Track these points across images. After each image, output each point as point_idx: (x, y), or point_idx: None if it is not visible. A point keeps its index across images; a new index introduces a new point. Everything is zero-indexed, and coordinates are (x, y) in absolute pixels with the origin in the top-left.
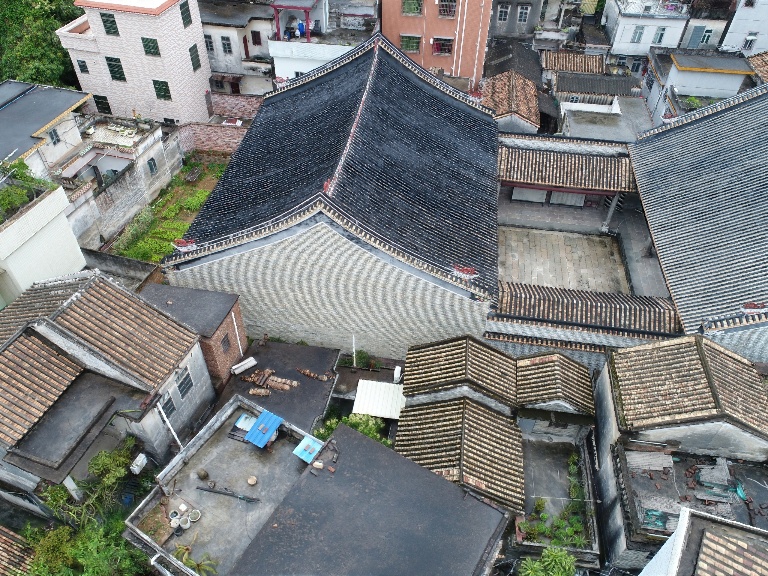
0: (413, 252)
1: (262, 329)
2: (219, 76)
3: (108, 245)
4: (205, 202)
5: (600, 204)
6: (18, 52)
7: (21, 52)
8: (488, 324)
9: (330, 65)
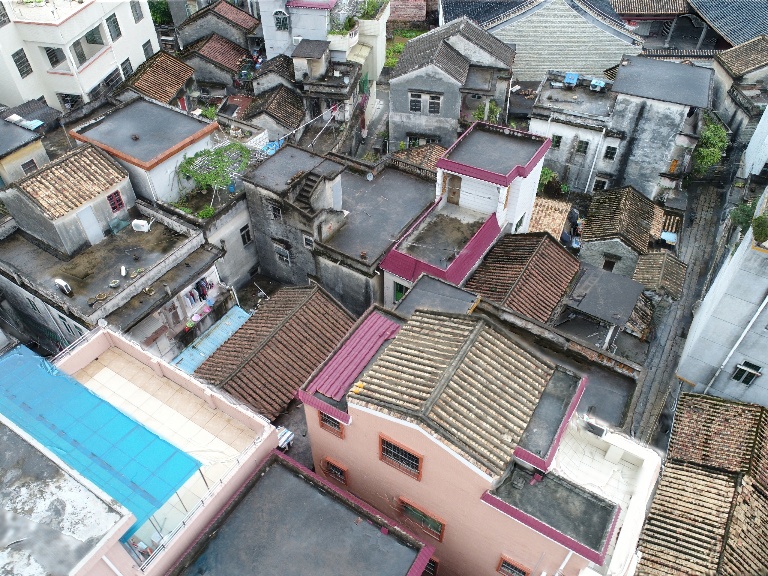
0: (605, 14)
1: None
2: None
3: None
4: None
5: (659, 34)
6: None
7: None
8: None
9: None
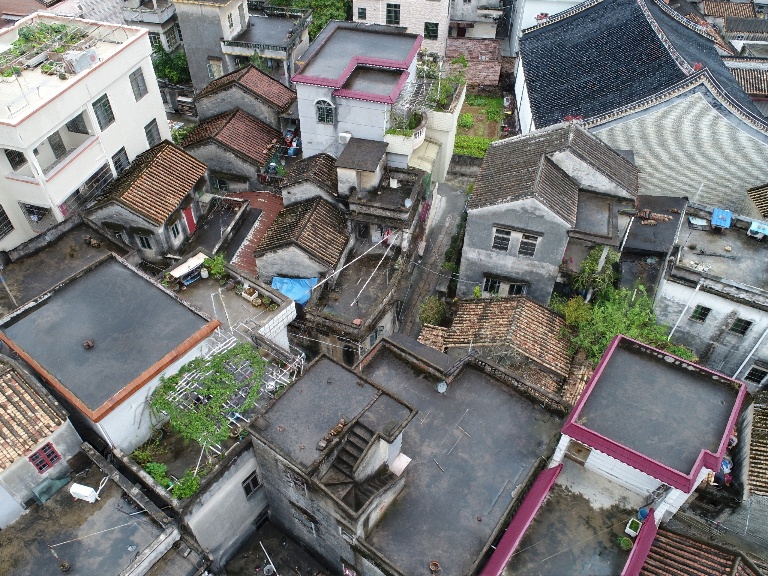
0: (756, 116)
1: None
2: (454, 23)
3: None
4: (531, 105)
5: None
6: (313, 1)
7: (315, 1)
8: None
9: (588, 3)
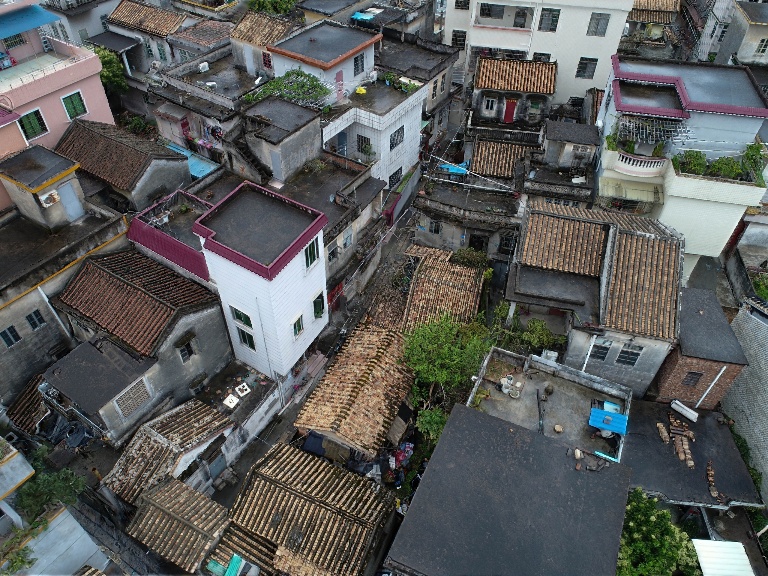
0: None
1: (748, 426)
2: None
3: (759, 270)
4: None
5: None
6: None
7: None
8: None
9: None
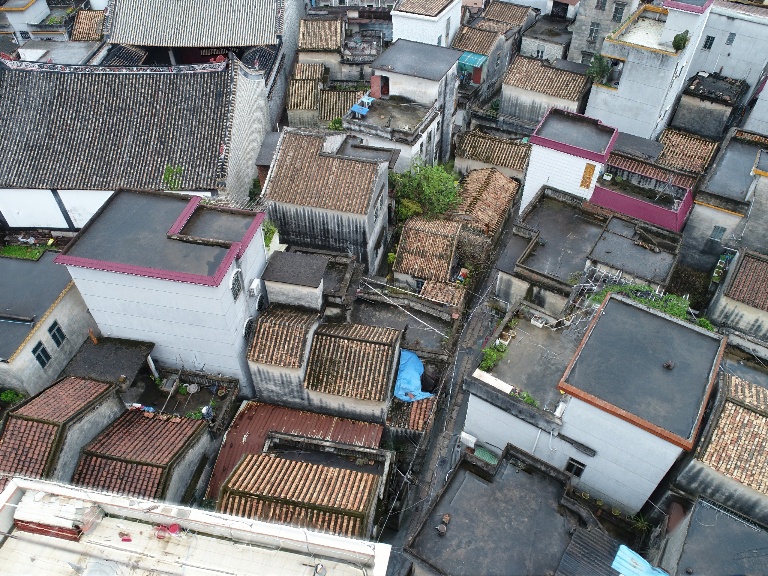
0: None
1: None
2: None
3: None
4: None
5: None
6: None
7: None
8: (266, 91)
9: None
